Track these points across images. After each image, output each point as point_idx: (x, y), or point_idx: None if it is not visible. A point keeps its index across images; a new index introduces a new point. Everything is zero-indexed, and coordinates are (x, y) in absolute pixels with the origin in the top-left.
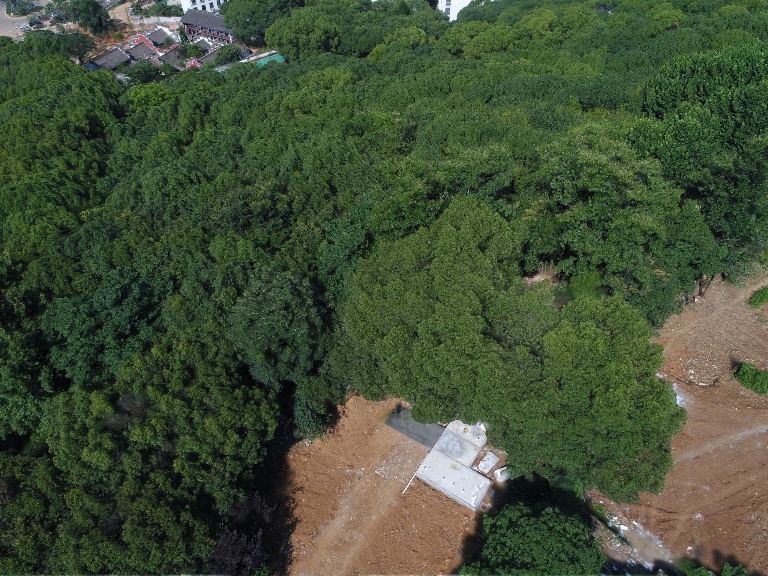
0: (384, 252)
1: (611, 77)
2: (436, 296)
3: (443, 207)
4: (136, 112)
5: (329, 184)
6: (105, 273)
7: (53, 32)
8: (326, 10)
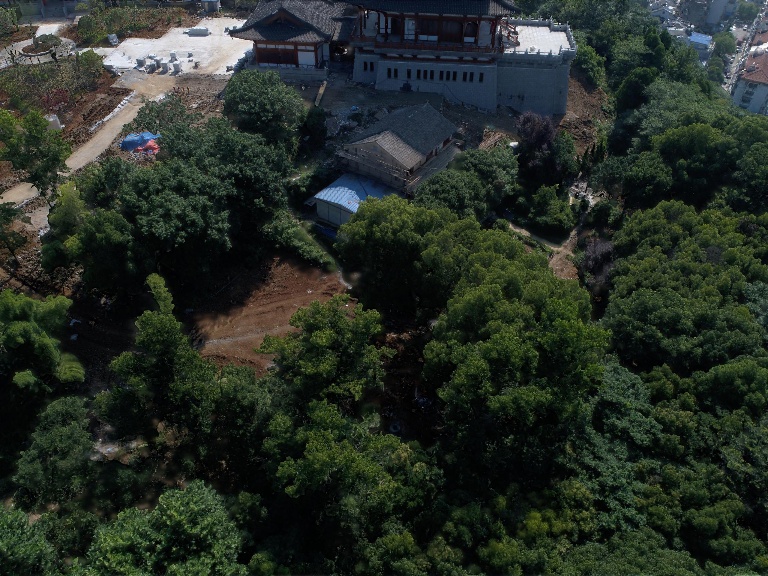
0: None
1: None
2: None
3: None
4: None
5: (704, 567)
6: None
7: None
8: None
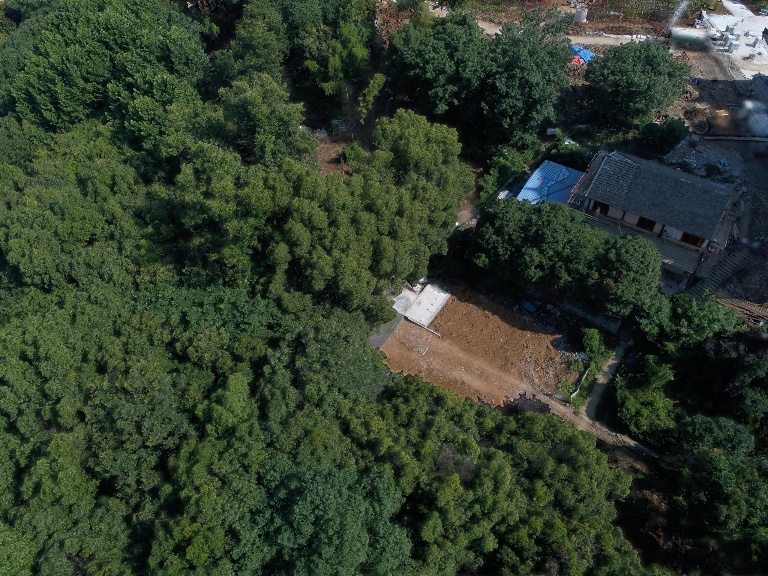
0: None
1: None
2: None
3: None
4: None
5: None
6: None
7: None
8: None
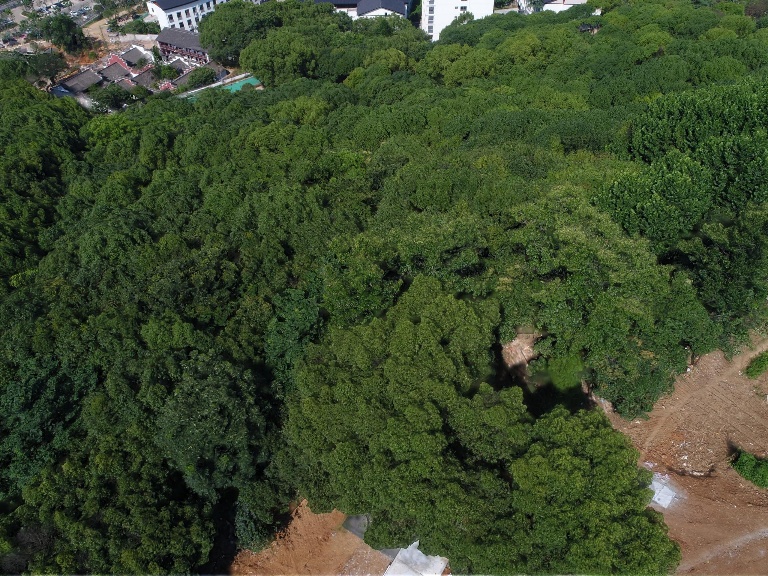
0: (336, 340)
1: (595, 113)
2: (391, 402)
3: (404, 285)
4: (96, 145)
5: (286, 244)
6: (23, 361)
7: (21, 53)
8: (303, 31)
